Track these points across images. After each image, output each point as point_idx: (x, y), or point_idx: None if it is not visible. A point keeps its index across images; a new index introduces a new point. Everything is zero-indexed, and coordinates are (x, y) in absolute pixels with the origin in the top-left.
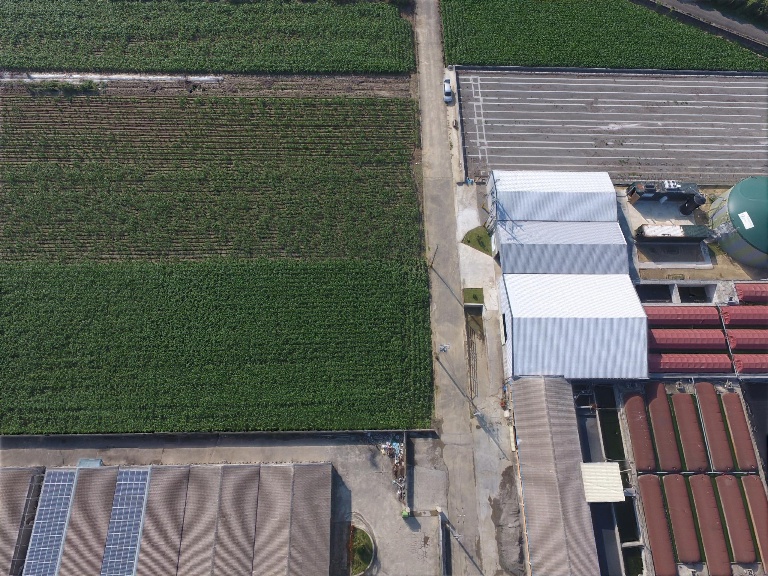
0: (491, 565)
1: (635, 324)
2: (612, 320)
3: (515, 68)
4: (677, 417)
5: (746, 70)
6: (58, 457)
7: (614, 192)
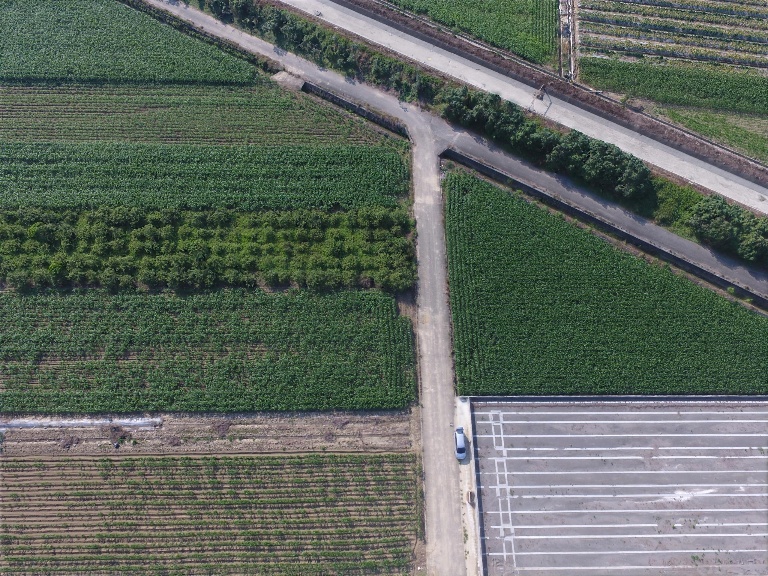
0: None
1: None
2: None
3: (548, 397)
4: None
5: None
6: None
7: None
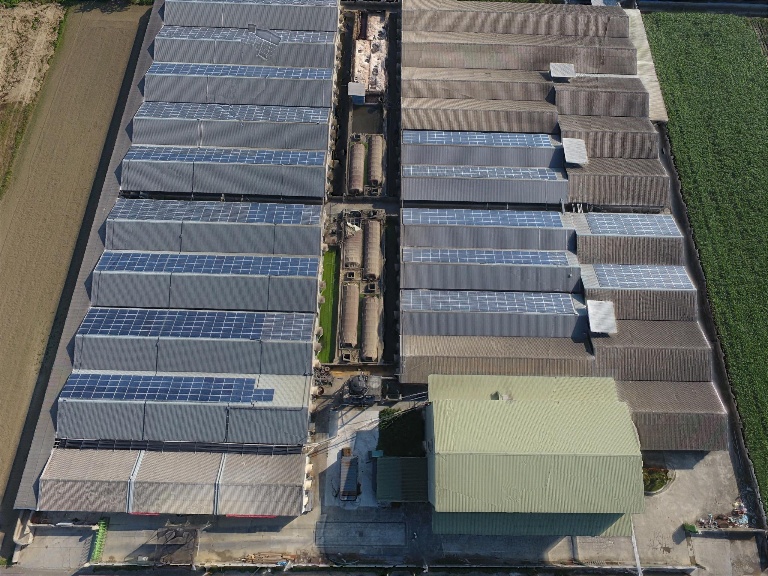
0: None
1: None
2: None
3: None
4: None
5: None
6: None
7: None
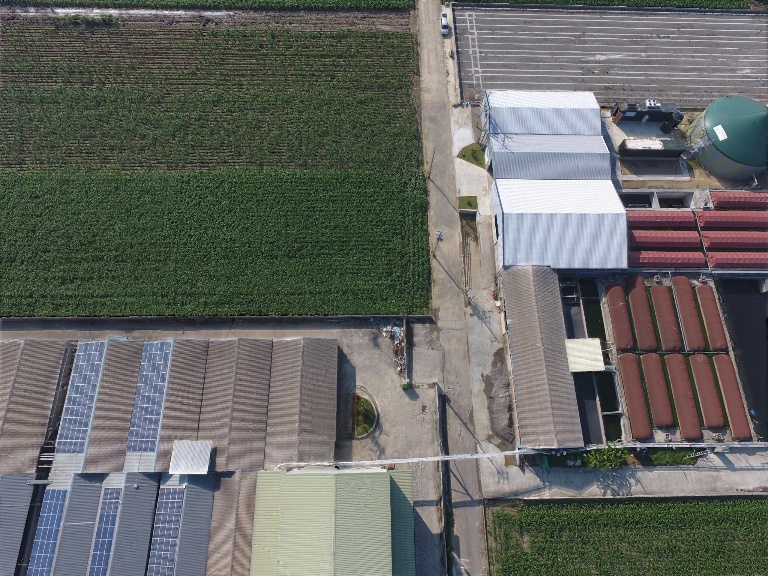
0: (483, 430)
1: (616, 219)
2: (595, 216)
3: (508, 5)
4: (655, 306)
5: (725, 8)
6: (88, 337)
7: (598, 108)
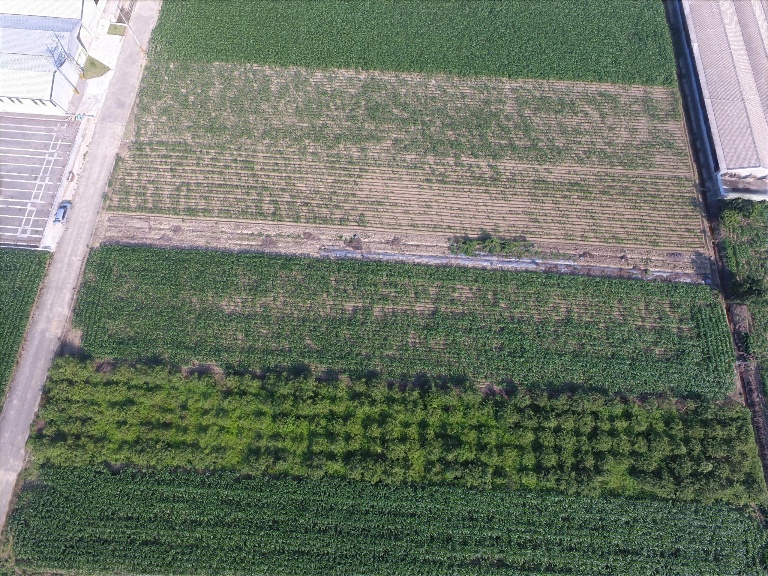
0: None
1: None
2: None
3: None
4: None
5: None
6: None
7: None
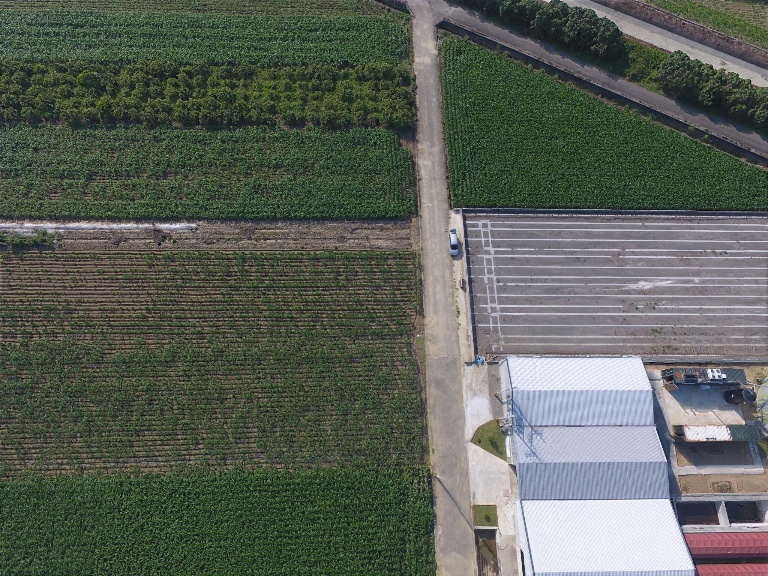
0: None
1: None
2: (653, 574)
3: (530, 210)
4: None
5: None
6: None
7: (650, 389)
